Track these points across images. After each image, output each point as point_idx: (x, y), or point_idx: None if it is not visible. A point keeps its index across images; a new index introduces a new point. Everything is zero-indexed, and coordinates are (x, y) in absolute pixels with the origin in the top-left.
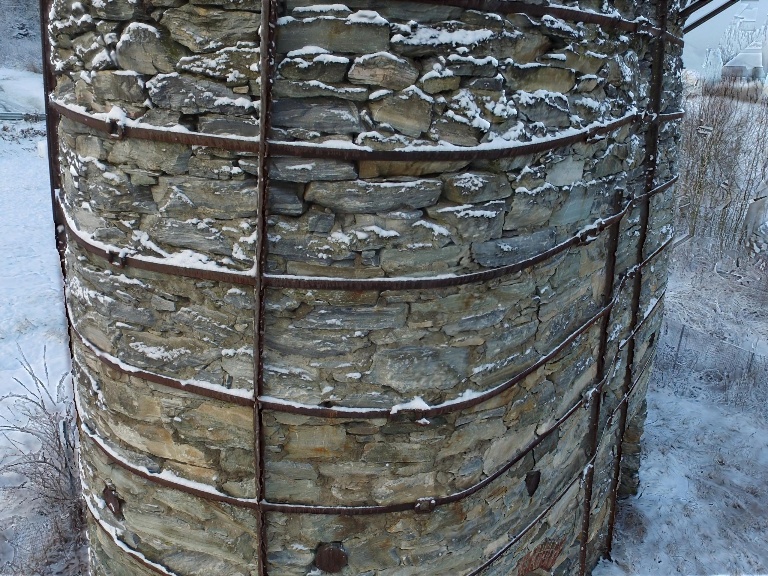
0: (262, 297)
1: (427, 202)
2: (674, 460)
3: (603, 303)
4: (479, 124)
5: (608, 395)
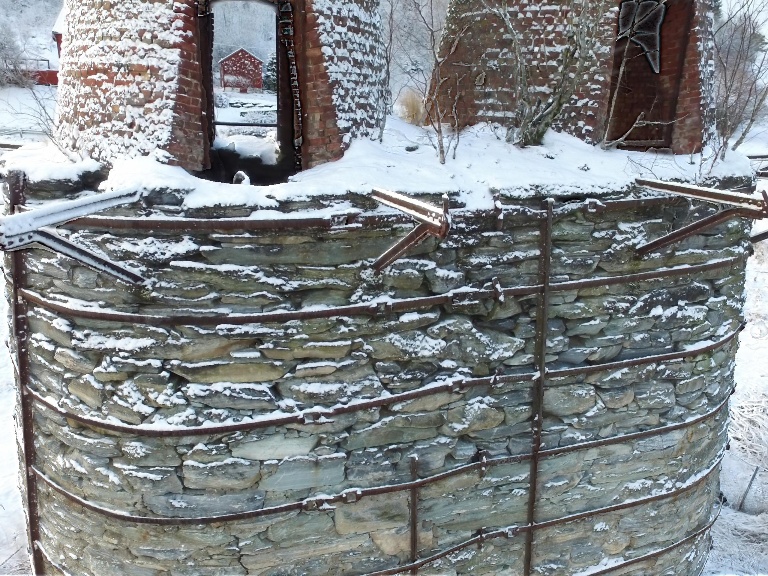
0: (34, 479)
1: (111, 454)
2: None
3: (410, 560)
4: (139, 409)
5: None
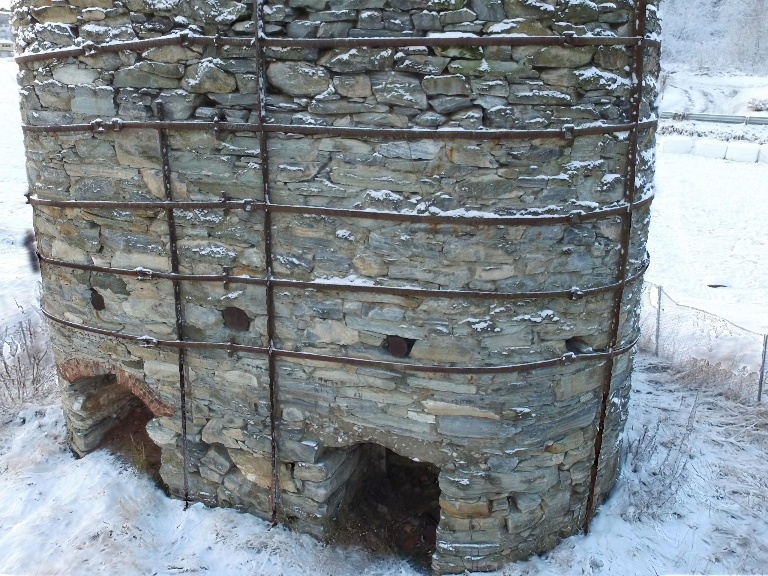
0: None
1: None
2: None
3: None
4: None
5: (251, 332)
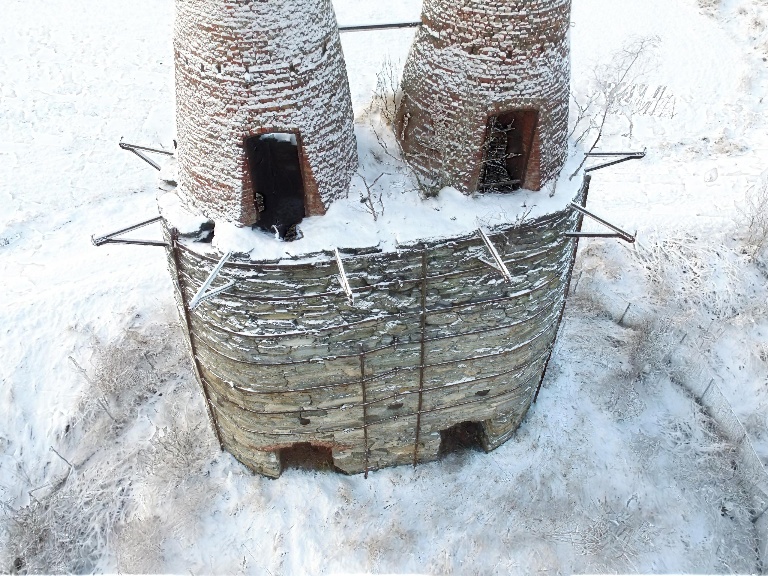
0: (193, 334)
1: None
2: (537, 454)
3: None
4: (238, 327)
5: (405, 407)
